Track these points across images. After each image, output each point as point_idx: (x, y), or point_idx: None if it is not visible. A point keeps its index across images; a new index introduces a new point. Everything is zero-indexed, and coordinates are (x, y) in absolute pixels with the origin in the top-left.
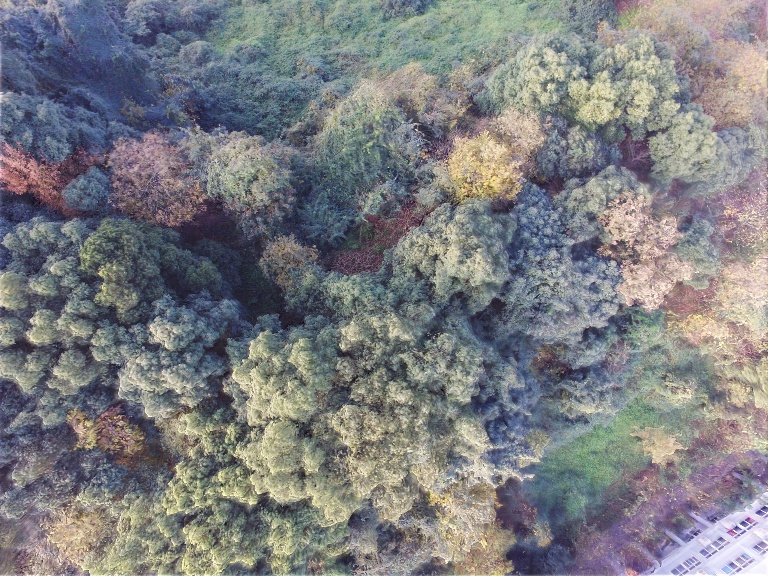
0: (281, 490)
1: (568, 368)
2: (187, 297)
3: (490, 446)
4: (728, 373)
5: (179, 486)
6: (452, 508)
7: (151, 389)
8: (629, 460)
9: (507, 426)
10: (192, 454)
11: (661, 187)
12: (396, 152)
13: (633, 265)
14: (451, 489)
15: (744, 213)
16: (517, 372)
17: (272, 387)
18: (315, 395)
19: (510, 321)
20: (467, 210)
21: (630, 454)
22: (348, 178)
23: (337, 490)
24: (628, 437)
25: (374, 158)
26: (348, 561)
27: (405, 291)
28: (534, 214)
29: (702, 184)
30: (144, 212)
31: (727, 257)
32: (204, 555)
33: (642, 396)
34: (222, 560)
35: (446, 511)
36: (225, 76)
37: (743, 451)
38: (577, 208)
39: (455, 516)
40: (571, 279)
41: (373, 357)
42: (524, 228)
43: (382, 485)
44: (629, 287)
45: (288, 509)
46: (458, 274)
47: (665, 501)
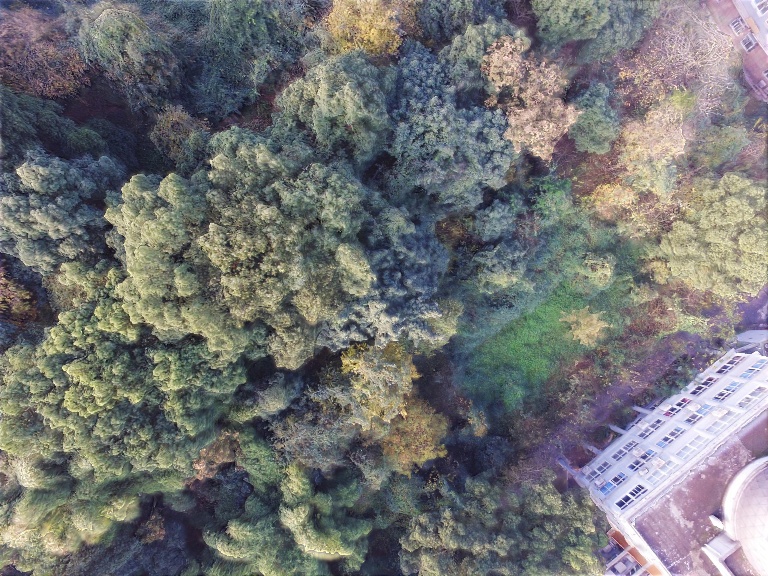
0: (155, 316)
1: (482, 244)
2: (68, 160)
3: (373, 277)
4: (649, 252)
5: (58, 329)
6: (364, 373)
7: (23, 233)
8: (564, 352)
9: (403, 276)
10: (74, 302)
11: (549, 44)
12: (282, 22)
13: (517, 110)
14: (362, 354)
15: (637, 72)
16: (407, 218)
17: (140, 217)
18: (180, 218)
19: (400, 173)
20: (343, 57)
21: (564, 345)
22: (238, 54)
23: (214, 317)
24: (560, 328)
25: (262, 31)
26: (266, 435)
27: (286, 140)
28: (416, 66)
29: (593, 45)
30: (24, 85)
31: (626, 119)
32: (85, 391)
33: (569, 283)
34: (101, 391)
35: (359, 378)
36: (138, 0)
37: (672, 331)
38: (458, 58)
39: (368, 382)
40: (454, 124)
41: (244, 188)
42: (407, 80)
43: (273, 328)
44: (513, 130)
45: (172, 347)
46: (332, 112)
47: (600, 387)
